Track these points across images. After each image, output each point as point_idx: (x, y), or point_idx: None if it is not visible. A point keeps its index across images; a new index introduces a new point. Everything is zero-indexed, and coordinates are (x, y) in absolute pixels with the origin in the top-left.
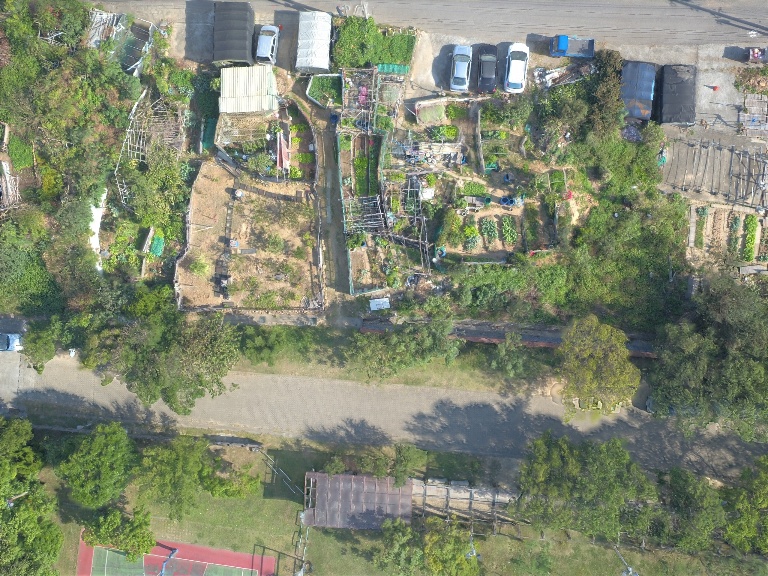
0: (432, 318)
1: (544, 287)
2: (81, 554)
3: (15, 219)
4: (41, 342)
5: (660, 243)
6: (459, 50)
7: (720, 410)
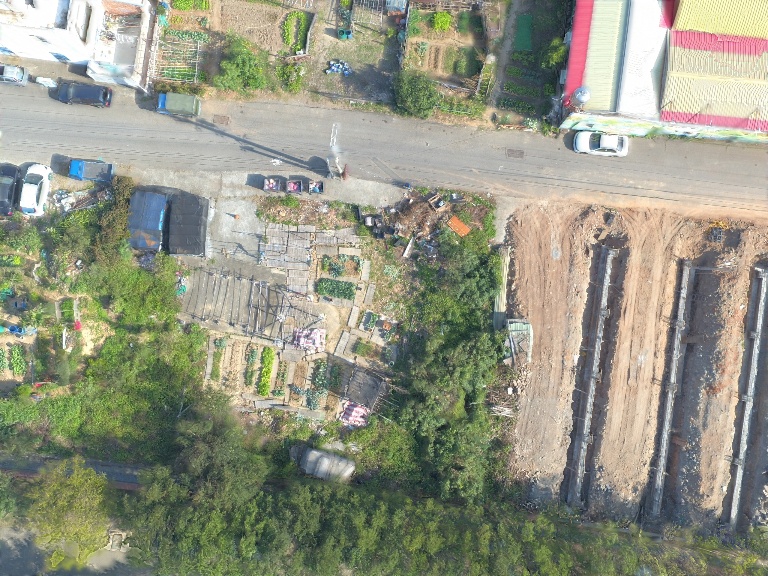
0: None
1: (57, 418)
2: None
3: None
4: None
5: (173, 375)
6: None
7: None
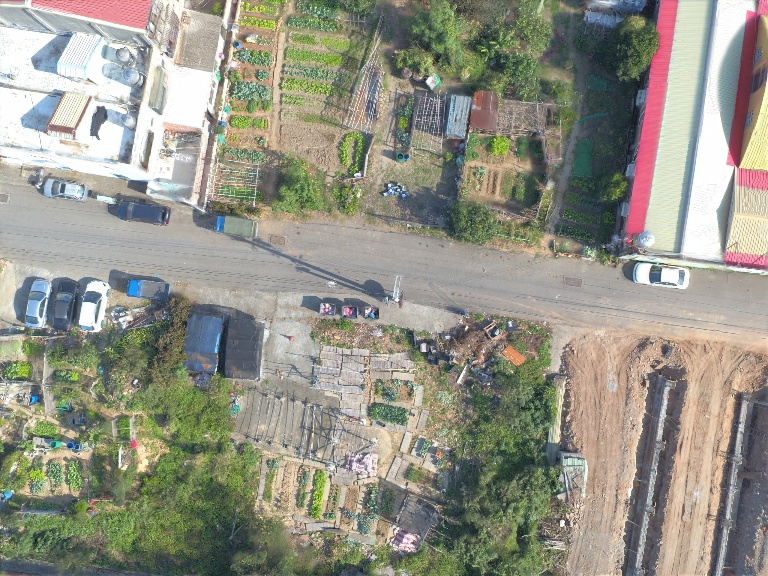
0: (5, 555)
1: (111, 533)
2: None
3: None
4: None
5: (226, 496)
6: (35, 286)
7: None
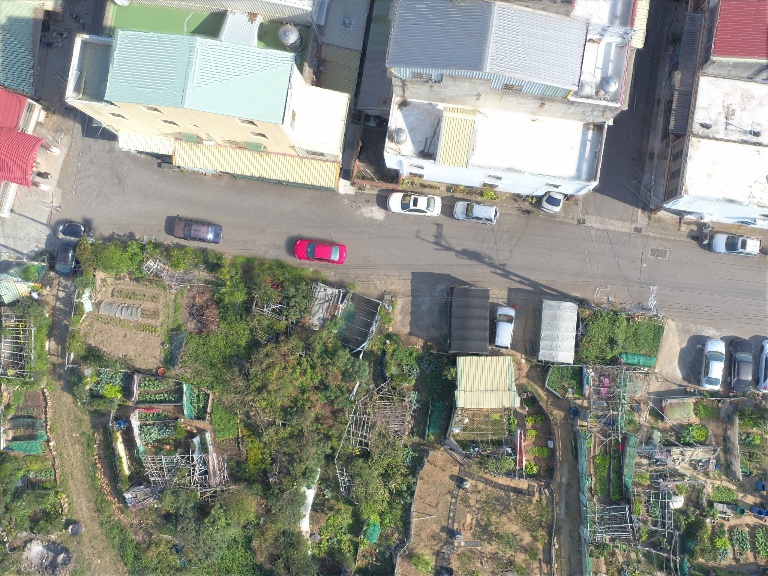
0: None
1: None
2: None
3: (224, 503)
4: None
5: None
6: (712, 346)
7: None
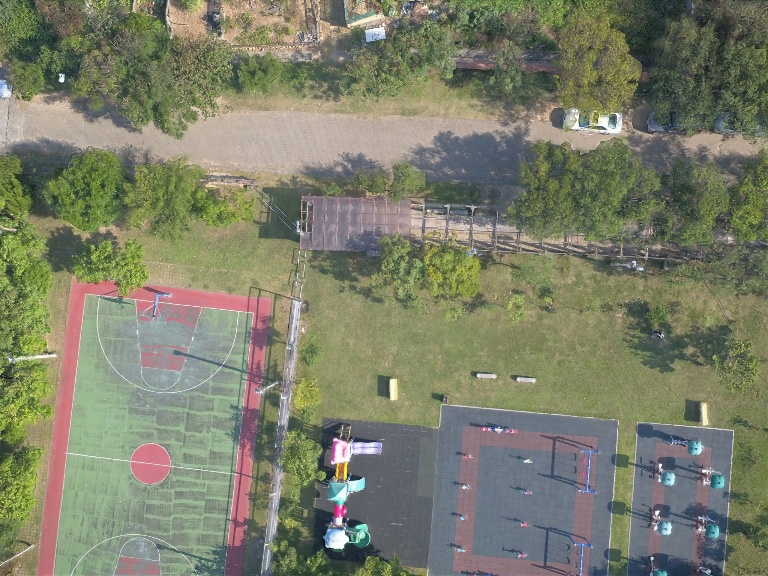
0: None
1: (542, 9)
2: (72, 303)
3: None
4: (30, 69)
5: None
6: None
7: (723, 96)
